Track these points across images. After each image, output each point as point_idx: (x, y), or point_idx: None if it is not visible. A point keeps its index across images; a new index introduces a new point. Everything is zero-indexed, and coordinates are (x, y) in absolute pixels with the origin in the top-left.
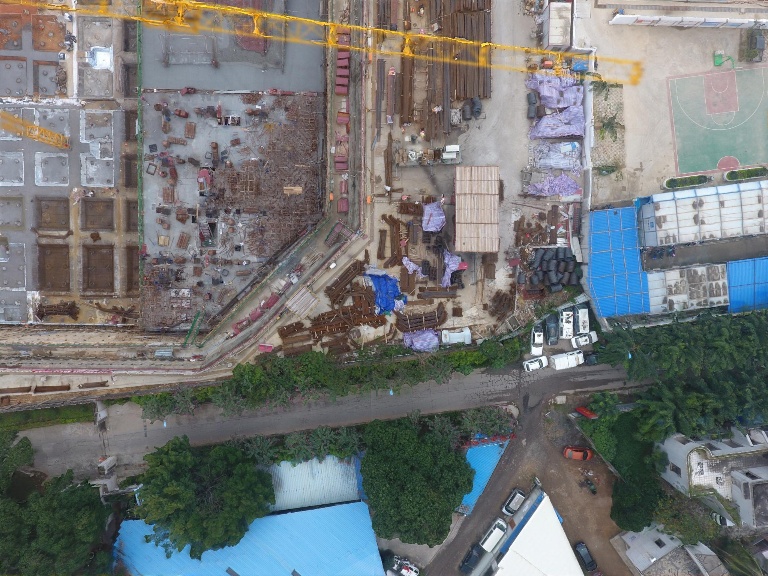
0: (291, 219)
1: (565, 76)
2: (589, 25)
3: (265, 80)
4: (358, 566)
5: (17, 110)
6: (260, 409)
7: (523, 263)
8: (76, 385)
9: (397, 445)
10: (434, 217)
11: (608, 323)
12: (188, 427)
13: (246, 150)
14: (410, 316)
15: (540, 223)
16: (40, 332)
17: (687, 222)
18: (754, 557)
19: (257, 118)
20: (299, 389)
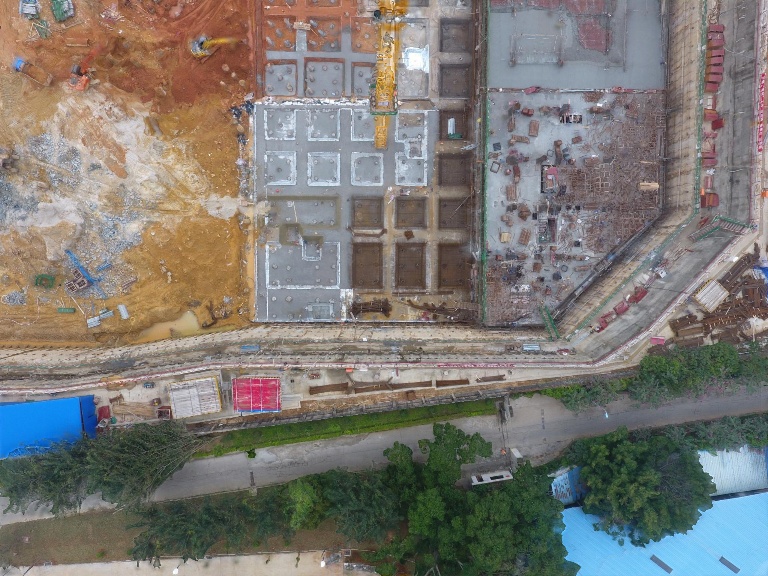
0: (630, 215)
1: None
2: None
3: (607, 78)
4: None
5: (333, 111)
6: None
7: None
8: (474, 379)
9: None
10: None
11: None
12: (584, 419)
13: (587, 147)
14: None
15: None
16: (372, 329)
17: None
18: None
19: (605, 116)
20: (716, 380)
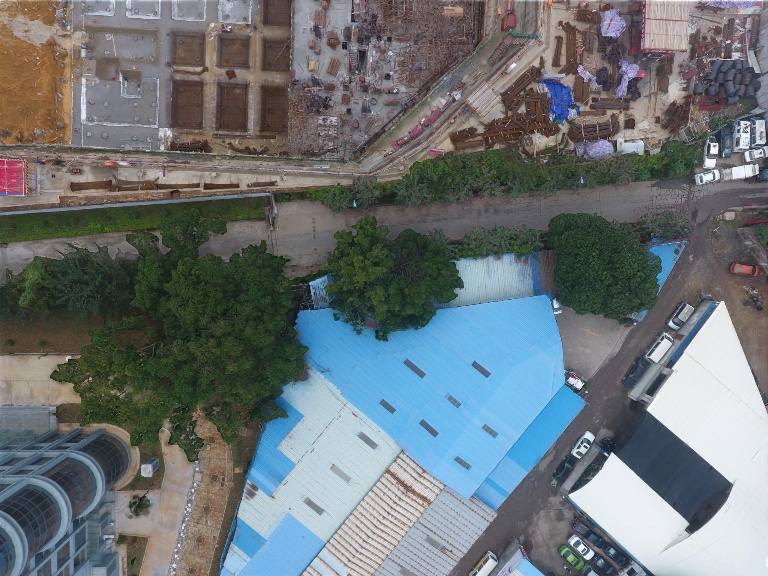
0: None
1: None
2: None
3: None
4: (540, 357)
5: None
6: (430, 214)
7: (699, 74)
8: (245, 184)
9: (592, 227)
10: (614, 22)
11: None
12: None
13: None
14: (584, 125)
15: (715, 37)
16: None
17: None
18: None
19: None
20: (481, 183)
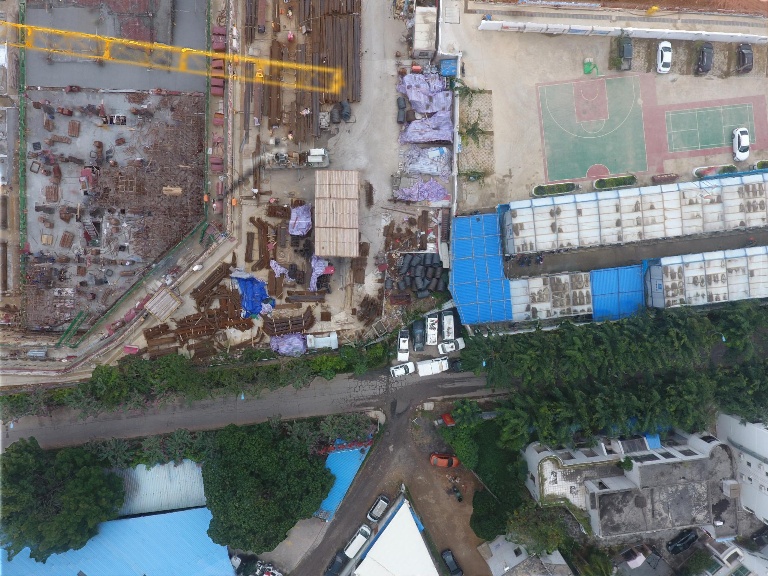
0: (176, 220)
1: (433, 81)
2: (458, 30)
3: (151, 79)
4: (208, 571)
5: None
6: None
7: (391, 268)
8: None
9: (243, 450)
10: (300, 221)
11: (472, 330)
12: (51, 428)
13: (131, 150)
14: (277, 320)
15: (410, 228)
16: None
17: (544, 230)
18: (619, 567)
19: (140, 118)
20: (155, 392)
